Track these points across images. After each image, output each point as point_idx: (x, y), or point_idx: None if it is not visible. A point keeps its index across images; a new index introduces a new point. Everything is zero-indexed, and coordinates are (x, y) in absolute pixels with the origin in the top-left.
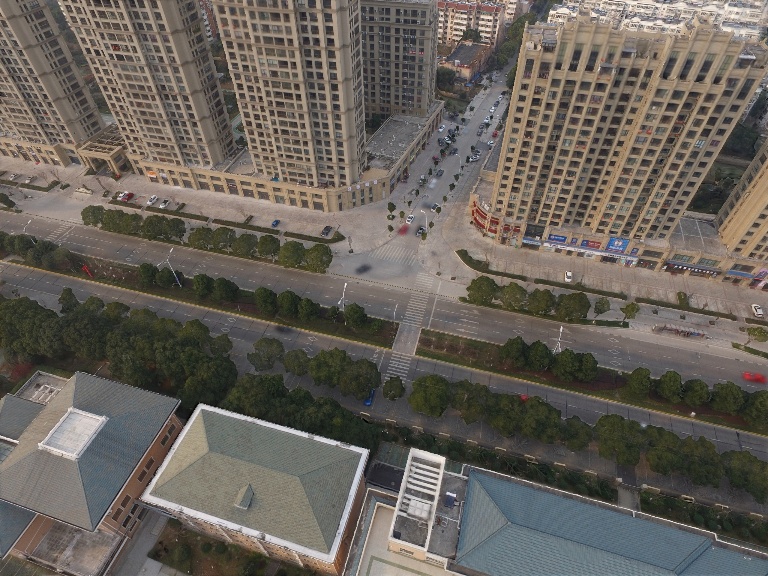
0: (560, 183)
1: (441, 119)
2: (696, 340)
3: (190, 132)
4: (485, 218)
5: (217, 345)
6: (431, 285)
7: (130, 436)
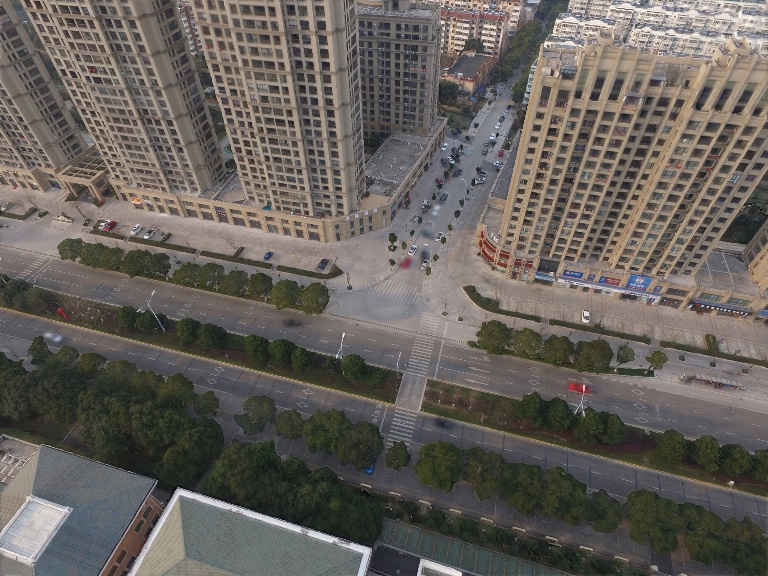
0: (577, 217)
1: (444, 137)
2: (729, 392)
3: (176, 158)
4: (494, 251)
5: (201, 404)
6: (437, 327)
7: (97, 530)
